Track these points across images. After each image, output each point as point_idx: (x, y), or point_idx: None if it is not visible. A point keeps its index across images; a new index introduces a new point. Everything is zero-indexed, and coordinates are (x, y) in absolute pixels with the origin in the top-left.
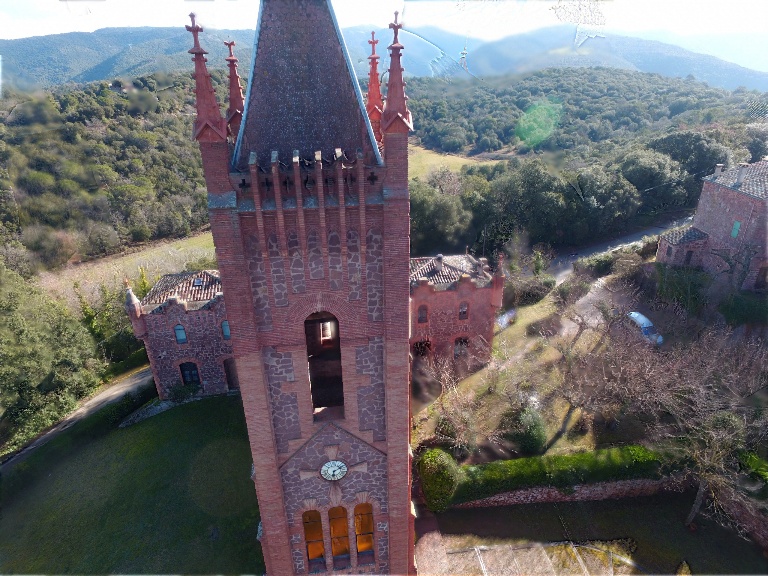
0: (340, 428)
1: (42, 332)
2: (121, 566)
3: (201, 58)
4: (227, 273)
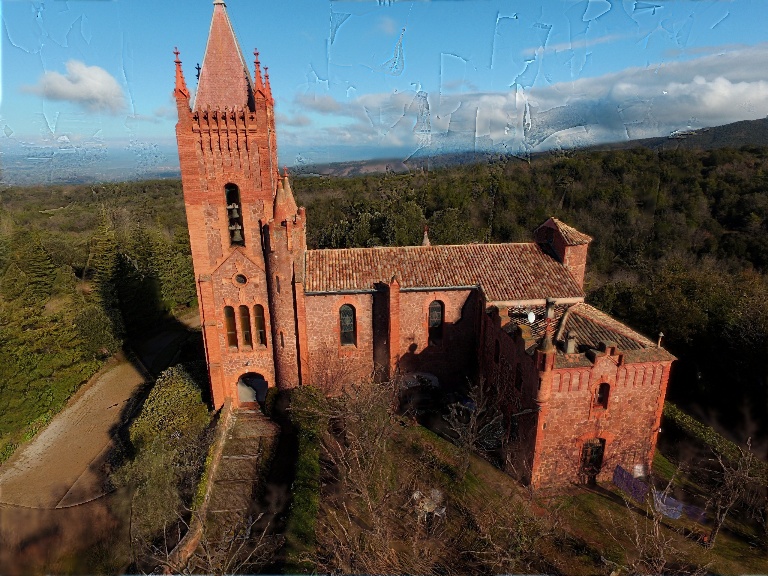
0: None
1: None
2: None
3: None
4: None
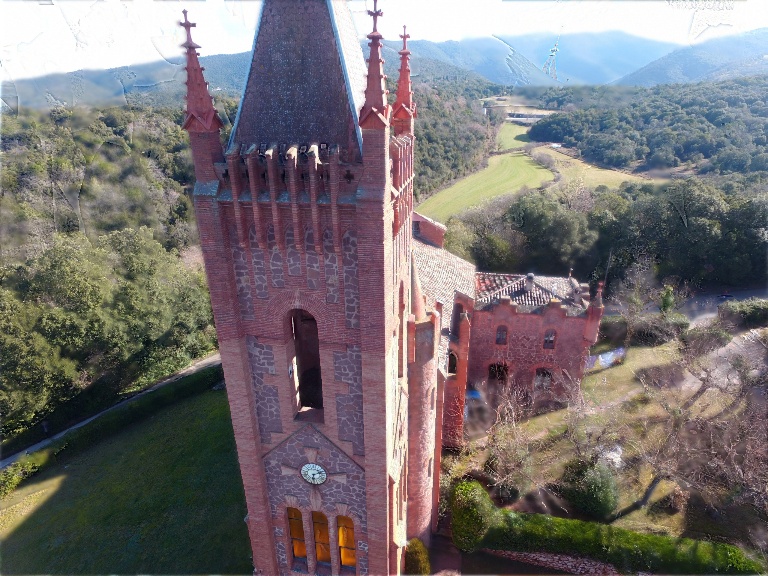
0: (319, 432)
1: (170, 296)
2: (174, 510)
3: (191, 52)
4: (210, 258)
